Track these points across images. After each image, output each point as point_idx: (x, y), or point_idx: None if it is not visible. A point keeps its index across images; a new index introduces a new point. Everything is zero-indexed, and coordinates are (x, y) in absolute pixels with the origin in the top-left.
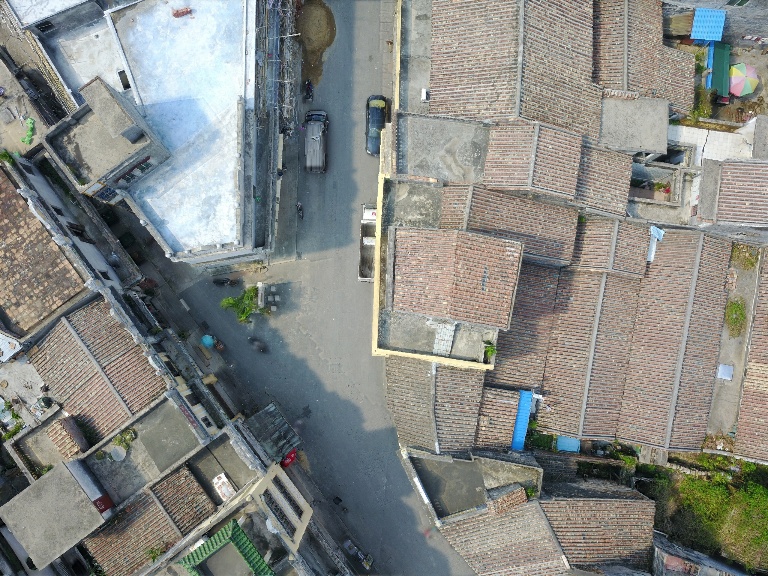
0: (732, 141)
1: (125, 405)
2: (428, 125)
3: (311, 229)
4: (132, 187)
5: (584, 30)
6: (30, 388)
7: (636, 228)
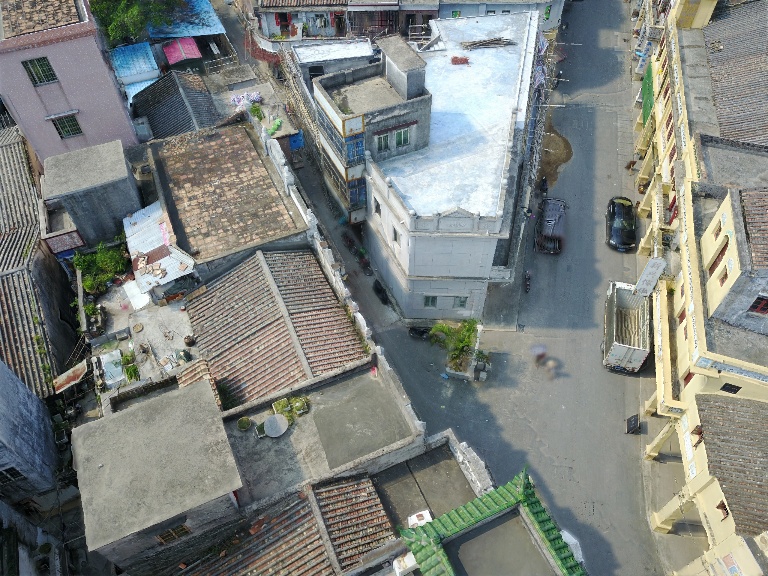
0: None
1: (307, 362)
2: (734, 156)
3: (537, 304)
4: (377, 164)
5: None
6: (170, 339)
7: None
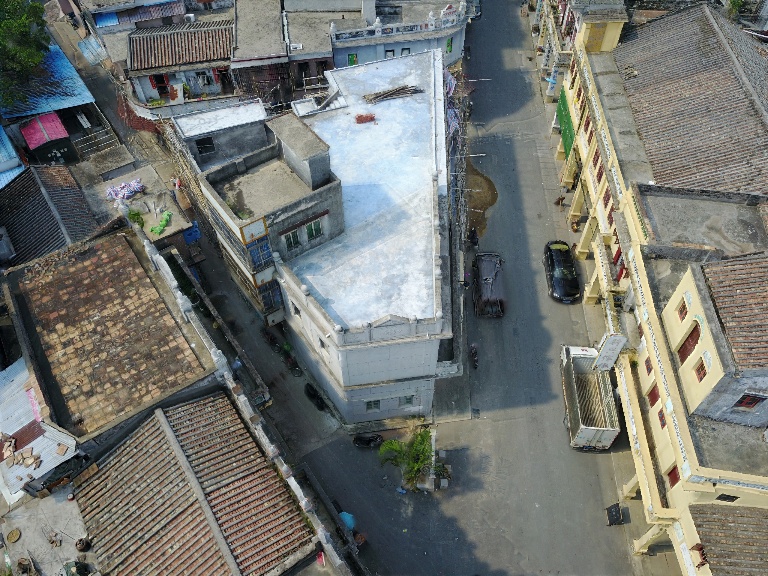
0: None
1: (235, 564)
2: (675, 203)
3: (489, 381)
4: (289, 263)
5: None
6: (58, 544)
7: None
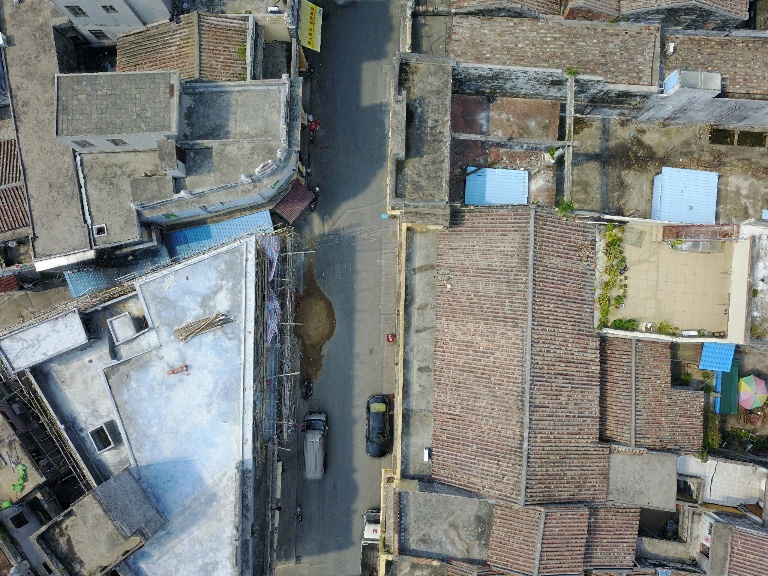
0: (741, 471)
1: None
2: (431, 497)
3: (310, 531)
4: None
5: (591, 391)
6: None
7: (644, 572)
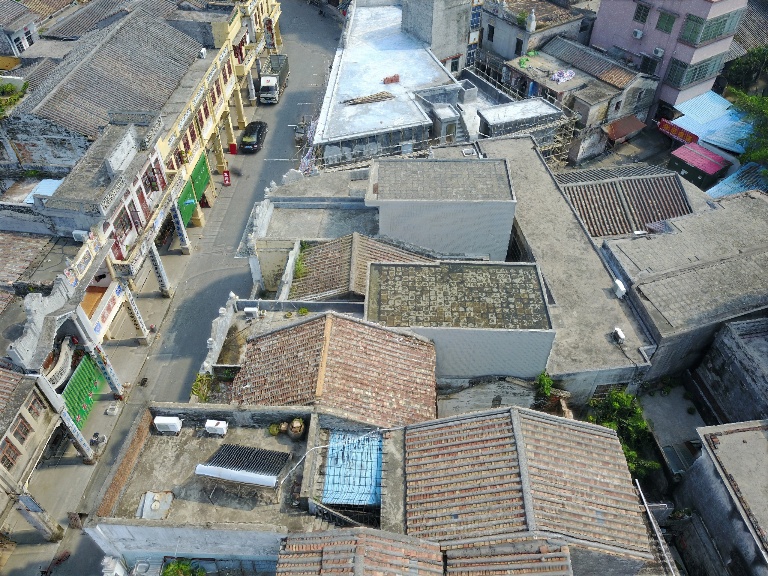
0: None
1: None
2: None
3: (321, 99)
4: None
5: None
6: None
7: None
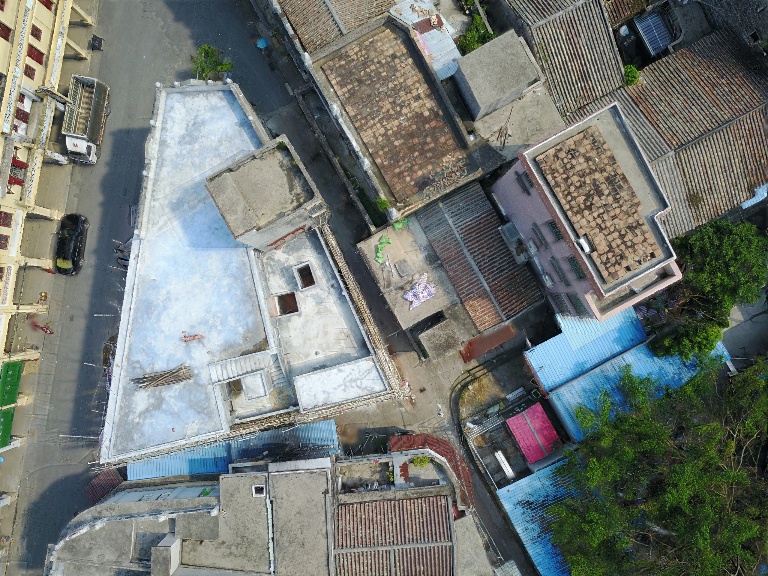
0: None
1: None
2: None
3: None
4: None
5: None
6: None
7: None
